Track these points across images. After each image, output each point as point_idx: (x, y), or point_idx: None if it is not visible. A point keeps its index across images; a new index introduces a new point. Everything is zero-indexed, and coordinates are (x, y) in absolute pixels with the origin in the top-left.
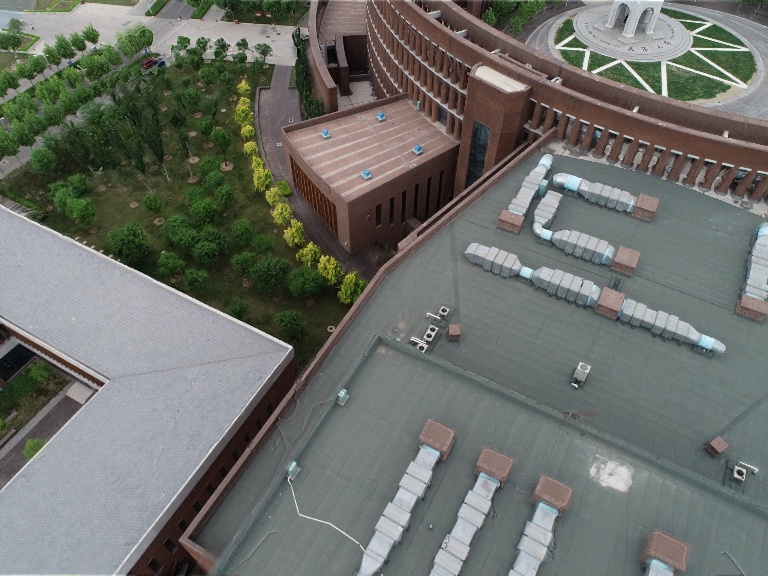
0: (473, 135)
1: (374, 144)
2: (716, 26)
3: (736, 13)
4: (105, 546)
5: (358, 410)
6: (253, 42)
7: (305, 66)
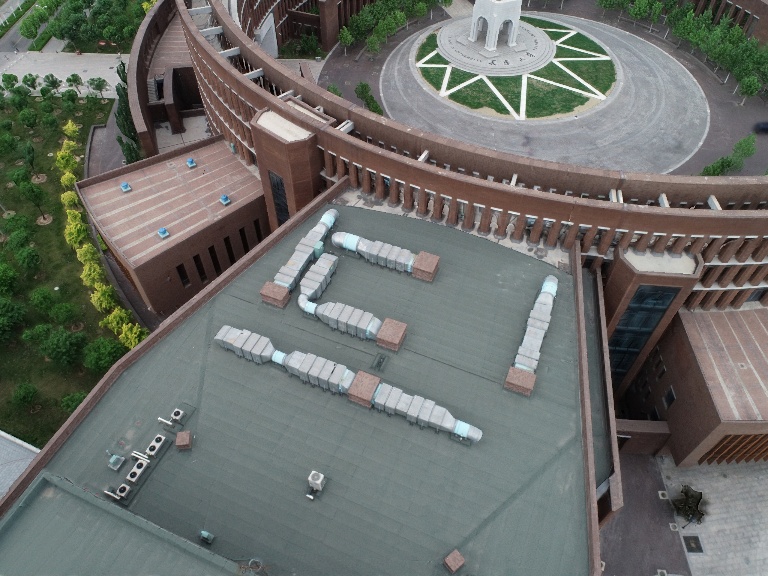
0: (272, 184)
1: (179, 195)
2: (580, 34)
3: (600, 20)
4: None
5: None
6: (94, 74)
7: (128, 105)
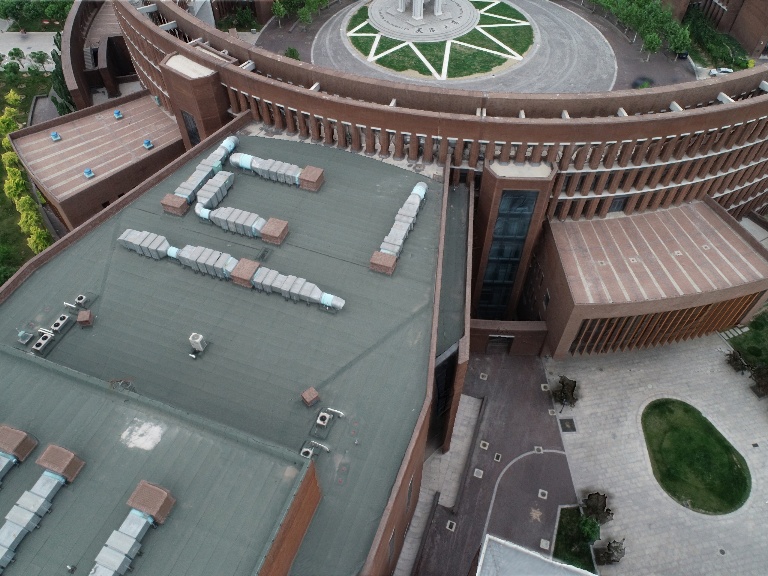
0: (186, 124)
1: (106, 142)
2: (503, 3)
3: None
4: None
5: None
6: None
7: None
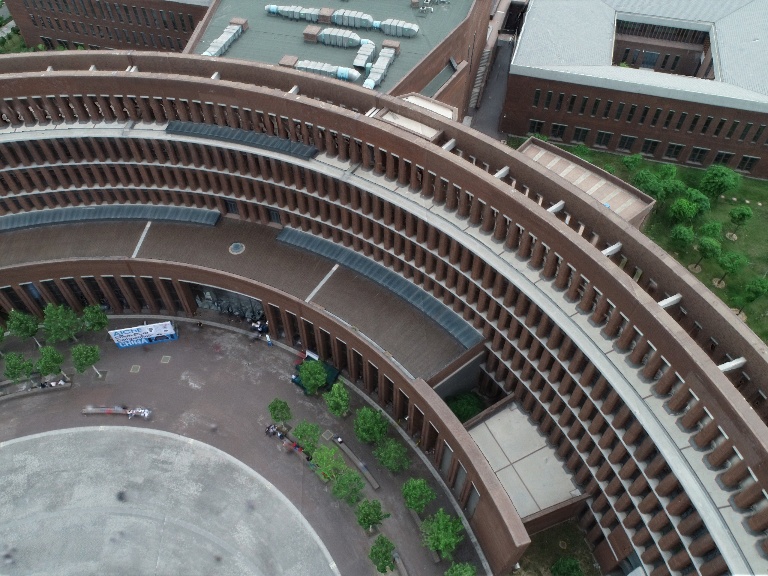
0: None
1: None
2: None
3: None
4: (544, 8)
5: None
6: None
7: None
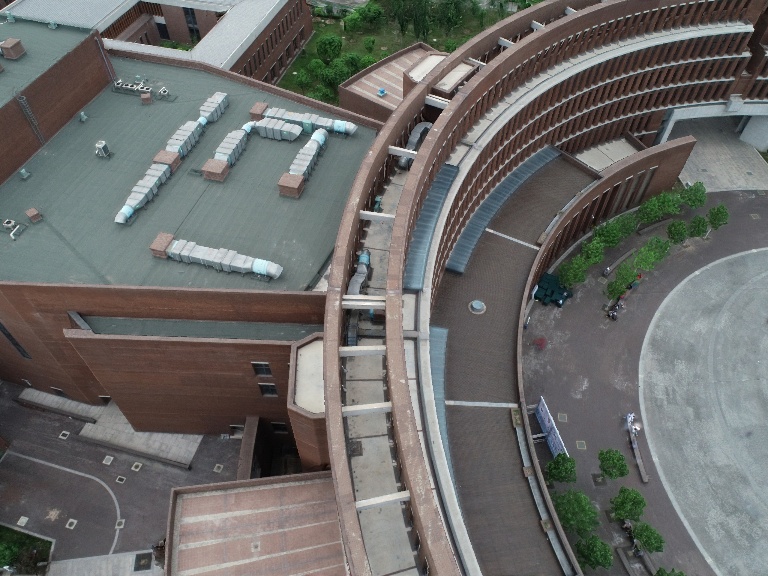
0: None
1: None
2: None
3: None
4: None
5: (42, 30)
6: None
7: None
